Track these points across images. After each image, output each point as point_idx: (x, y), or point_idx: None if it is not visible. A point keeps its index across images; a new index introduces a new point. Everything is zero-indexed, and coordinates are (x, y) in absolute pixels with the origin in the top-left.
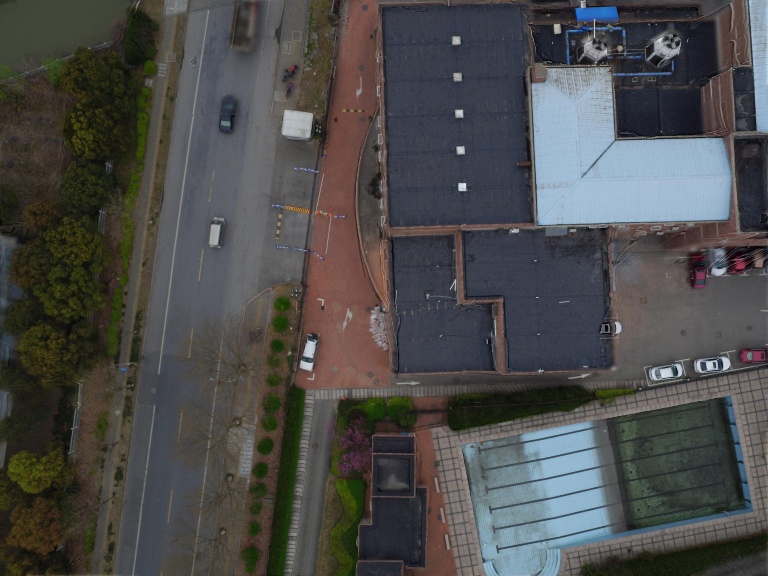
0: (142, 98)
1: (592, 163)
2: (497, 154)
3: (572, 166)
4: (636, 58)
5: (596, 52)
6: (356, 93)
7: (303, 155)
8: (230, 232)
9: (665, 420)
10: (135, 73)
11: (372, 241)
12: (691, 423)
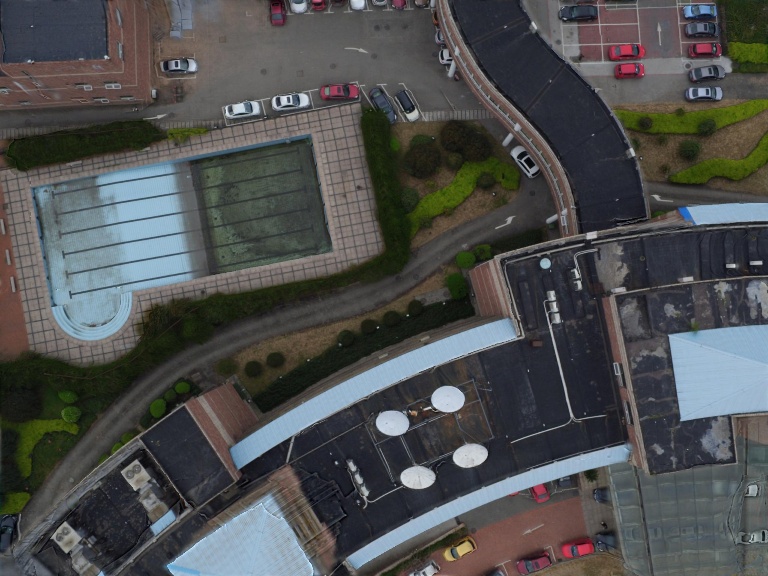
0: None
1: None
2: None
3: None
4: None
5: None
6: None
7: None
8: None
9: (252, 165)
10: None
11: None
12: (279, 168)
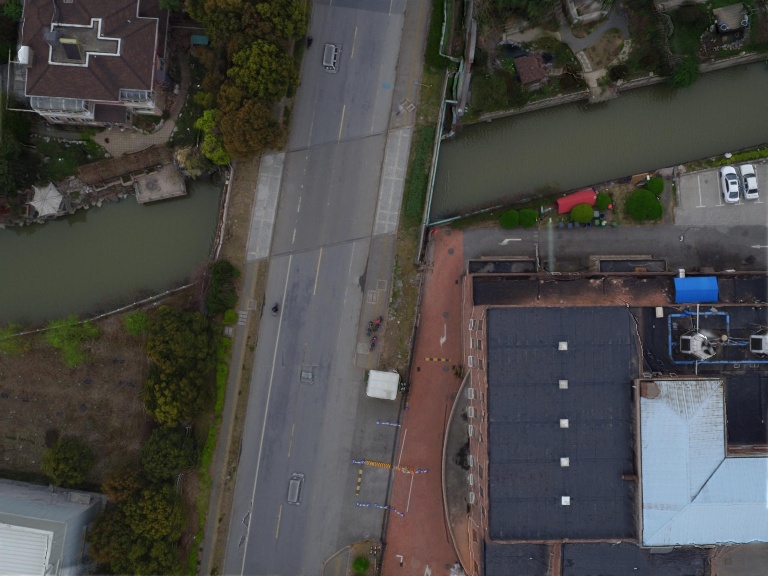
0: (222, 349)
1: (702, 485)
2: (601, 464)
3: (682, 489)
4: (739, 345)
5: (704, 354)
6: (440, 341)
7: (385, 408)
8: (309, 488)
9: None
10: (215, 322)
11: (459, 514)
12: None
